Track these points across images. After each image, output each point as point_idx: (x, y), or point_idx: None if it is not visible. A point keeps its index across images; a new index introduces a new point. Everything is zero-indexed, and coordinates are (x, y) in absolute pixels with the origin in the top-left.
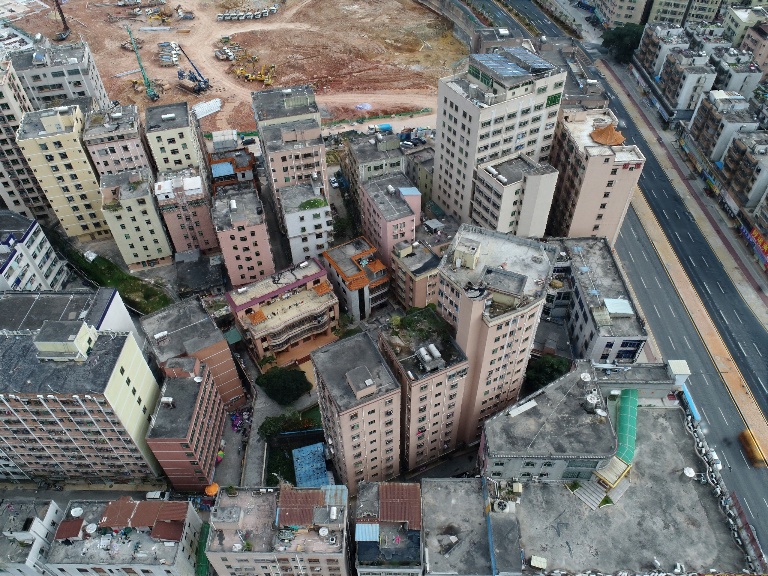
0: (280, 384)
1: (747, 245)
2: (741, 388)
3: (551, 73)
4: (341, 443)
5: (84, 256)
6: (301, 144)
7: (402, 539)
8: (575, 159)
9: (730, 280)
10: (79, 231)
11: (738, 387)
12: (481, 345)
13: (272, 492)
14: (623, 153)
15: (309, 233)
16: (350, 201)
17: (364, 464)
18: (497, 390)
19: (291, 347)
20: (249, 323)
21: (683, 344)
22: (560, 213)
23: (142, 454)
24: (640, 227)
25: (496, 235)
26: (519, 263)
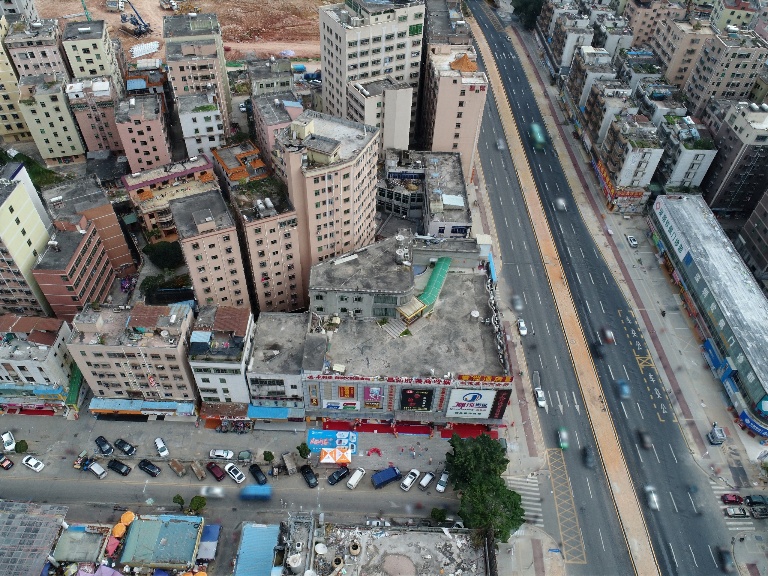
0: (161, 250)
1: (596, 176)
2: (559, 279)
3: (410, 4)
4: (191, 276)
5: (7, 153)
6: (198, 58)
7: (231, 346)
8: (434, 83)
9: (575, 202)
10: (3, 131)
11: (557, 278)
12: (305, 198)
13: (130, 309)
14: (473, 78)
15: (202, 135)
16: (254, 123)
17: (216, 302)
18: (330, 248)
19: None
20: (140, 202)
21: (521, 246)
22: (428, 135)
23: (31, 289)
24: (509, 159)
25: (332, 119)
26: (345, 139)
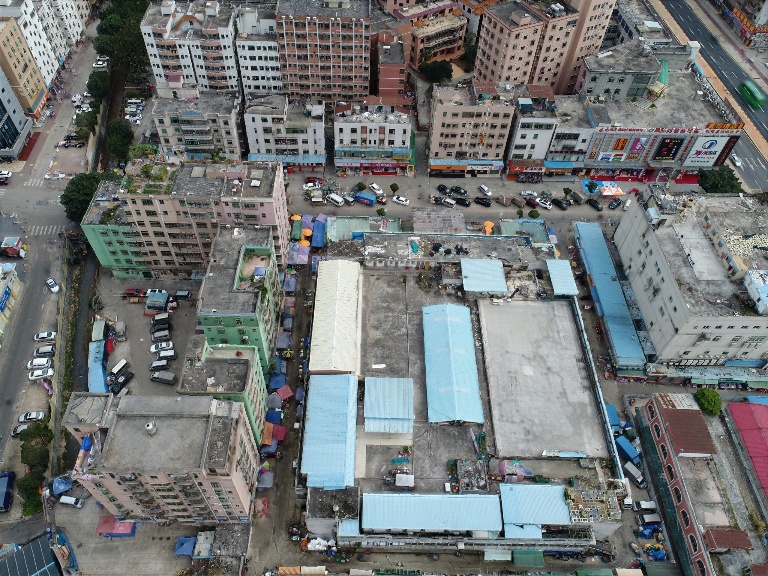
0: (438, 65)
1: (729, 23)
2: (724, 91)
3: None
4: (502, 64)
5: None
6: None
7: None
8: None
9: (717, 41)
10: None
11: (722, 90)
12: (588, 2)
13: (465, 87)
14: None
15: None
16: None
17: None
18: (587, 50)
19: (433, 56)
20: None
21: None
22: None
23: None
24: (655, 12)
25: None
26: None
